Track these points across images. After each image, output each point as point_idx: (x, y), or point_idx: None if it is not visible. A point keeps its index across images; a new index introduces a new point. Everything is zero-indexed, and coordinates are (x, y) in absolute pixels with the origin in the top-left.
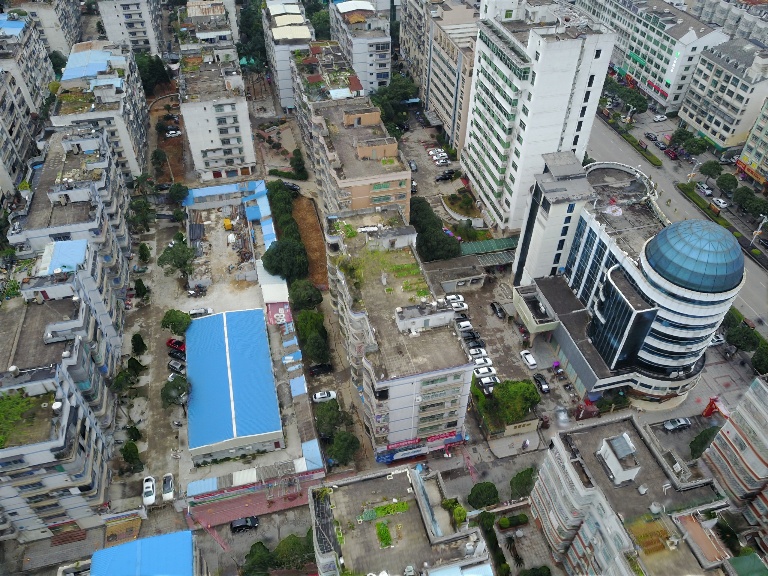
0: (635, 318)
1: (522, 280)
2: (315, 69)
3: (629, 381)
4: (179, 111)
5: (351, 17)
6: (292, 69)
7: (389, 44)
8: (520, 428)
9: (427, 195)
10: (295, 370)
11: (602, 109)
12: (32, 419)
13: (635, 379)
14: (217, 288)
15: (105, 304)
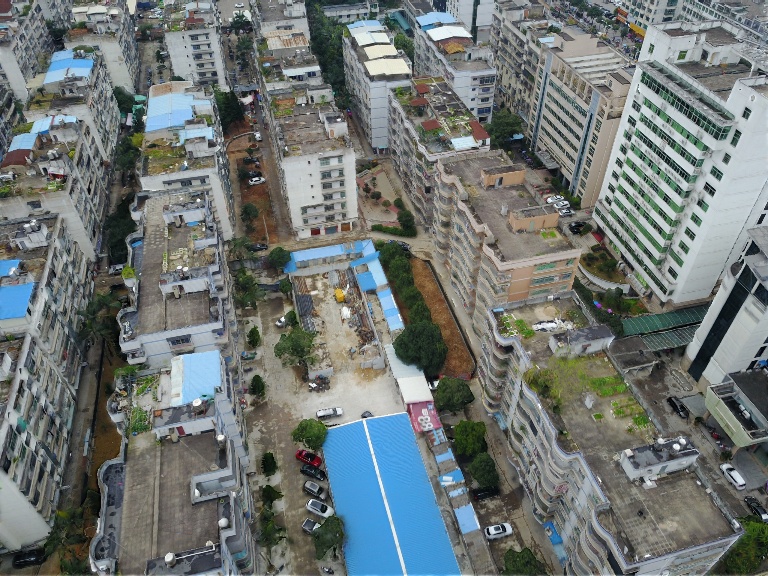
0: None
1: (707, 371)
2: (423, 111)
3: None
4: (258, 153)
5: (447, 46)
6: (393, 109)
7: (494, 77)
8: None
9: None
10: (458, 496)
11: None
12: None
13: None
14: (341, 379)
15: (237, 424)
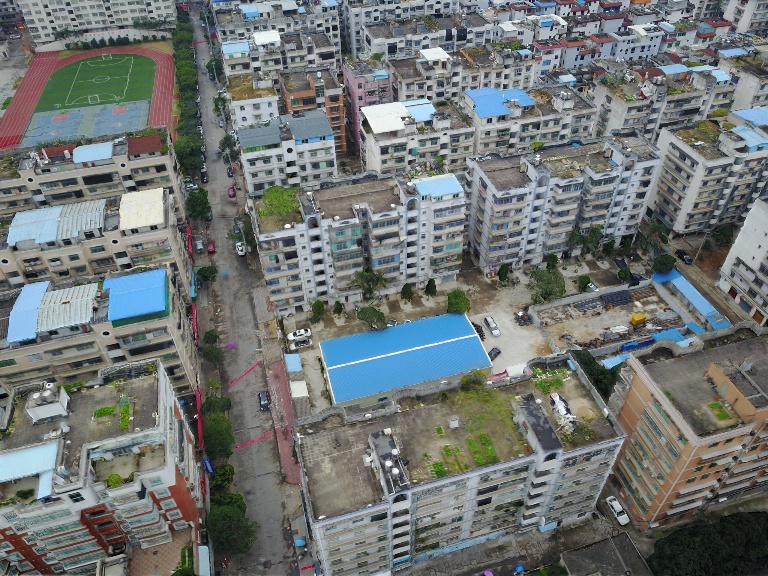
0: None
1: None
2: None
3: None
4: None
5: None
6: None
7: None
8: None
9: None
10: None
11: None
12: (281, 220)
13: None
14: (534, 333)
15: (435, 240)
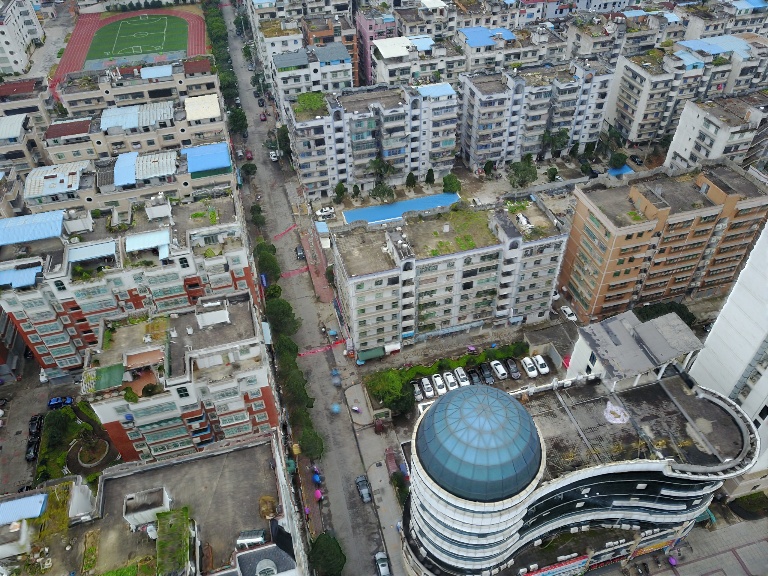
0: None
1: None
2: None
3: None
4: None
5: None
6: None
7: None
8: None
9: None
10: None
11: None
12: (312, 115)
13: None
14: None
15: (433, 136)
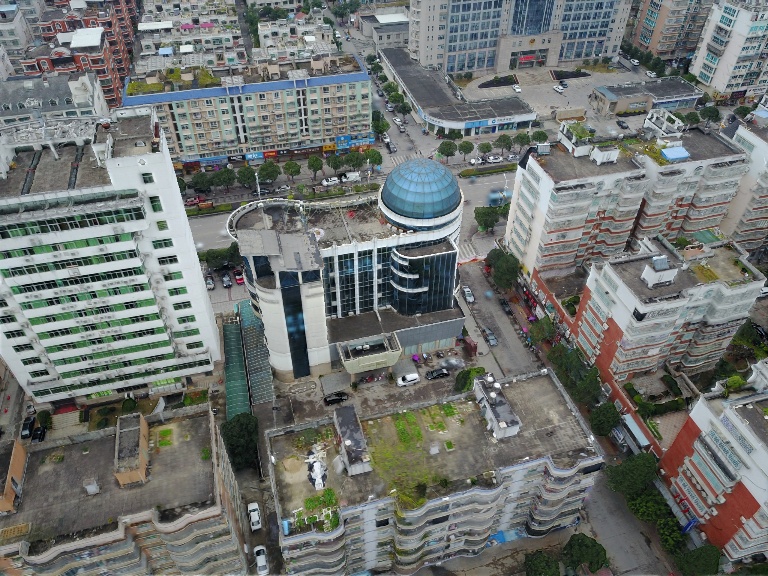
0: None
1: (312, 361)
2: None
3: None
4: None
5: None
6: None
7: None
8: None
9: None
10: None
11: None
12: None
13: None
14: None
15: None
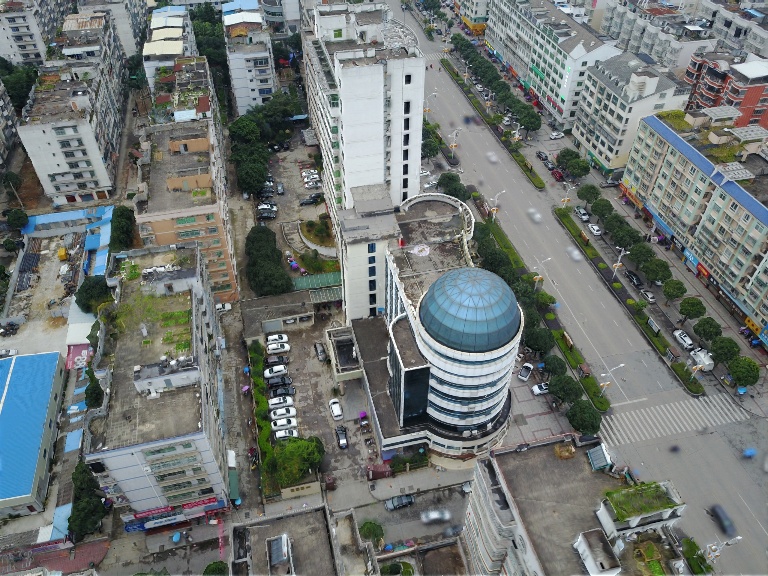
0: (405, 376)
1: (346, 320)
2: None
3: (425, 438)
4: None
5: (234, 30)
6: None
7: (268, 59)
8: (299, 491)
9: (285, 221)
10: (76, 422)
11: (497, 126)
12: None
13: (428, 437)
14: (30, 326)
15: None
